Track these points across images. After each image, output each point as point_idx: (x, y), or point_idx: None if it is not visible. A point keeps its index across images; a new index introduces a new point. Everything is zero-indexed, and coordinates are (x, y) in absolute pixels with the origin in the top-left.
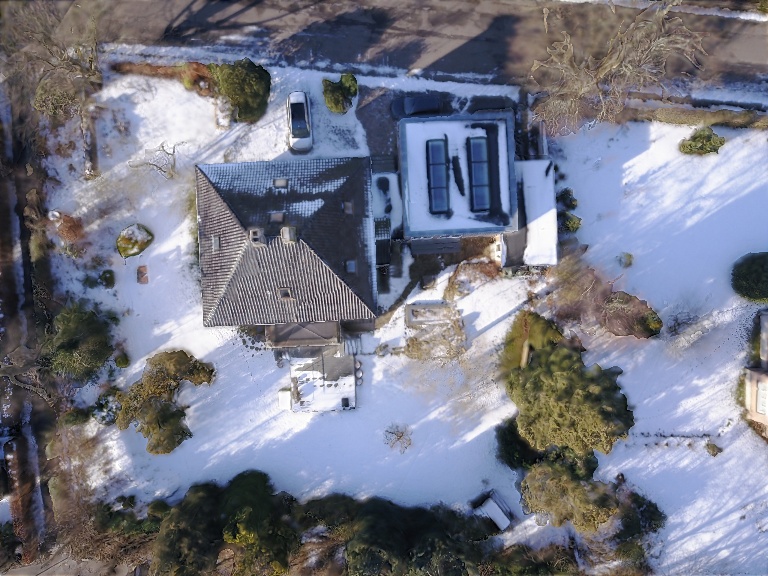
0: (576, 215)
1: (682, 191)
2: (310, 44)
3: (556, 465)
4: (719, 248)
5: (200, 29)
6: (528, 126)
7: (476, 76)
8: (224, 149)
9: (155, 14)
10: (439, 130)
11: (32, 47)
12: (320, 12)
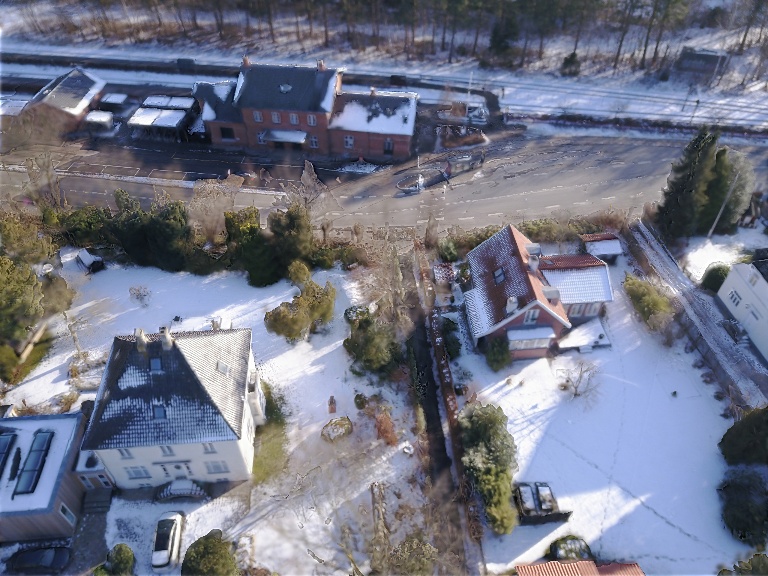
0: None
1: None
2: None
3: (22, 264)
4: None
5: None
6: None
7: None
8: (250, 516)
9: None
10: (17, 503)
11: None
12: None
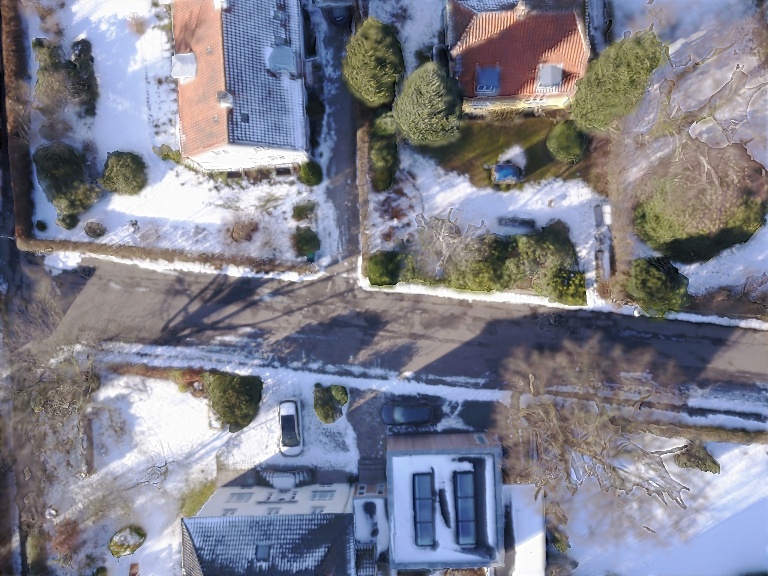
0: (567, 527)
1: (677, 505)
2: (302, 345)
3: None
4: (715, 566)
5: (195, 329)
6: (520, 432)
7: (468, 380)
8: (216, 449)
9: (152, 314)
10: (426, 463)
11: (34, 344)
12: (313, 314)
